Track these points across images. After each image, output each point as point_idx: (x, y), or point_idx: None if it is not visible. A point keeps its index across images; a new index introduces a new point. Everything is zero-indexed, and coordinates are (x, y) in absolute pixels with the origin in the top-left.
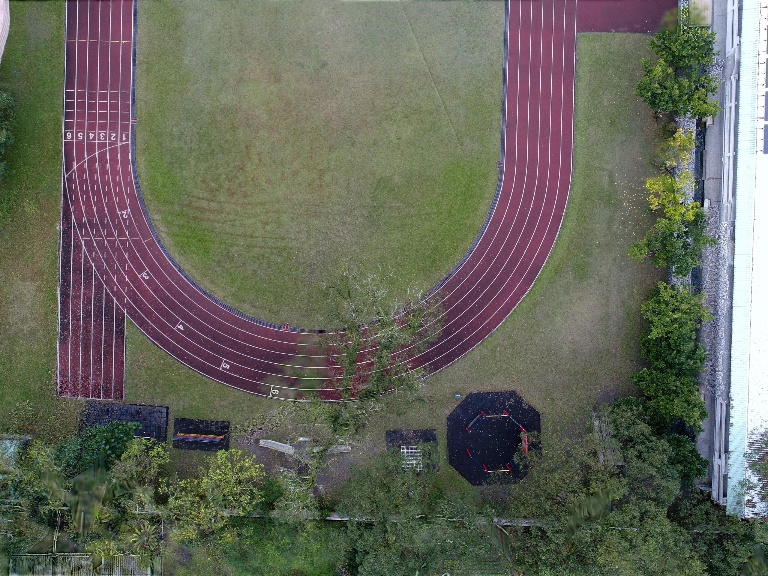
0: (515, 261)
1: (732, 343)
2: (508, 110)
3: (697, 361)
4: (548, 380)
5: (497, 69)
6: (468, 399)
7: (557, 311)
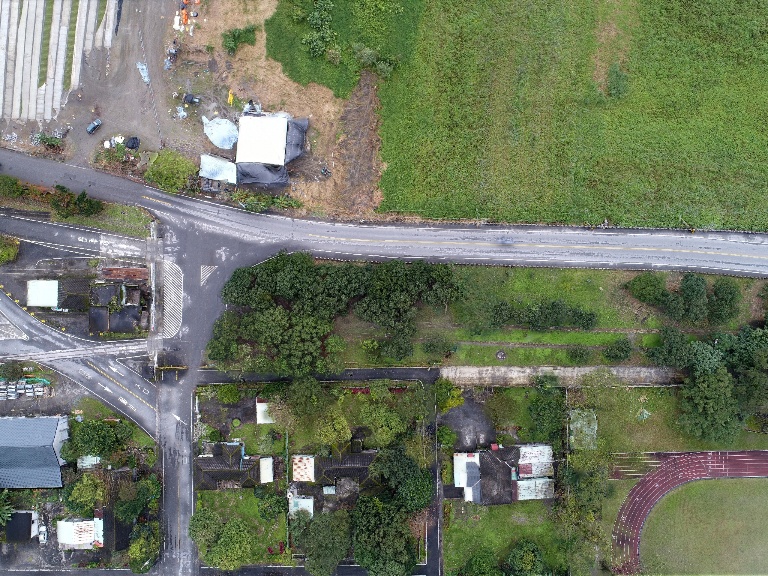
0: None
1: None
2: None
3: None
4: None
5: None
6: None
7: None
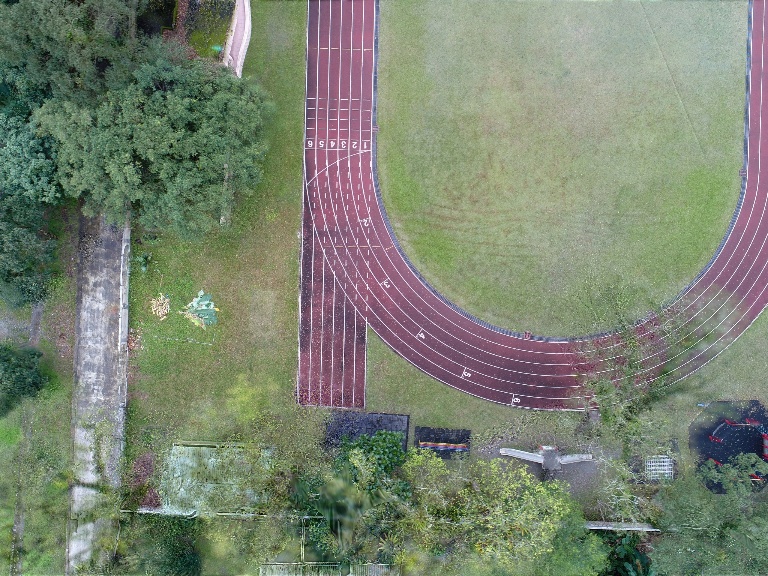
0: (758, 269)
1: None
2: (751, 118)
3: None
4: None
5: (740, 77)
6: (710, 408)
7: None
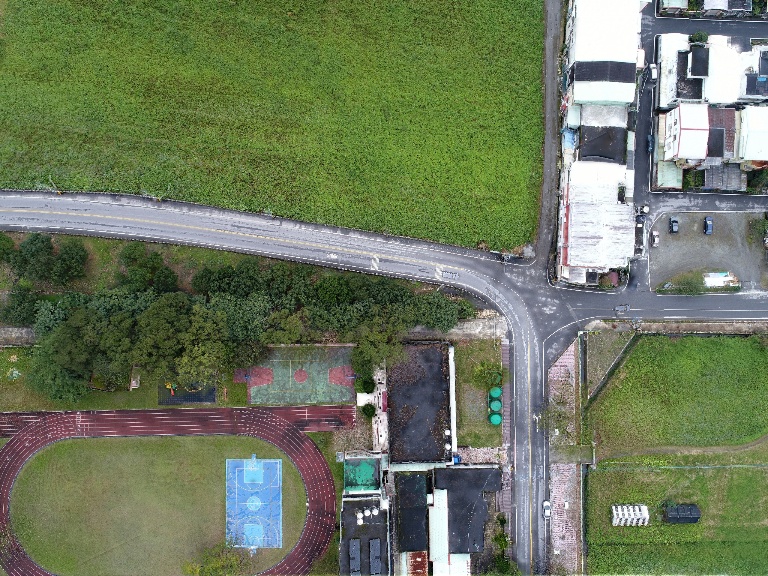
0: None
1: None
2: None
3: None
4: None
5: (112, 575)
6: None
7: None
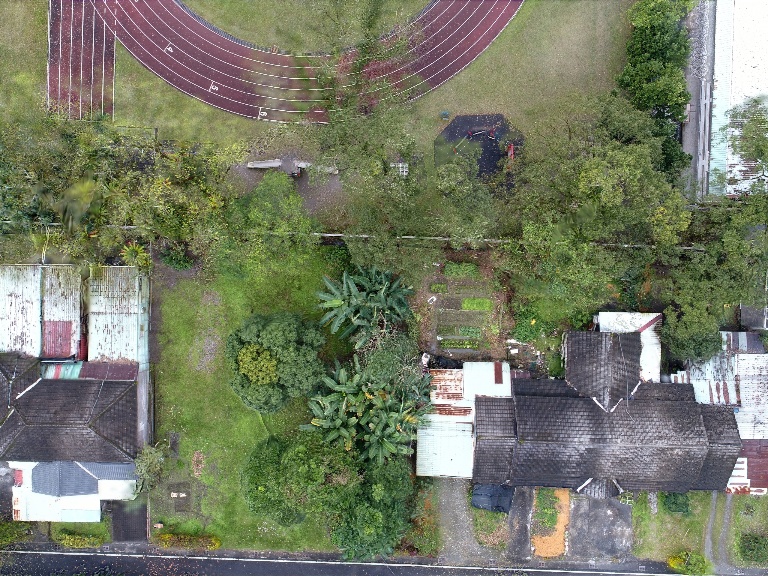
0: None
1: (716, 24)
2: None
3: (681, 48)
4: (535, 103)
5: None
6: (455, 122)
7: (544, 34)
